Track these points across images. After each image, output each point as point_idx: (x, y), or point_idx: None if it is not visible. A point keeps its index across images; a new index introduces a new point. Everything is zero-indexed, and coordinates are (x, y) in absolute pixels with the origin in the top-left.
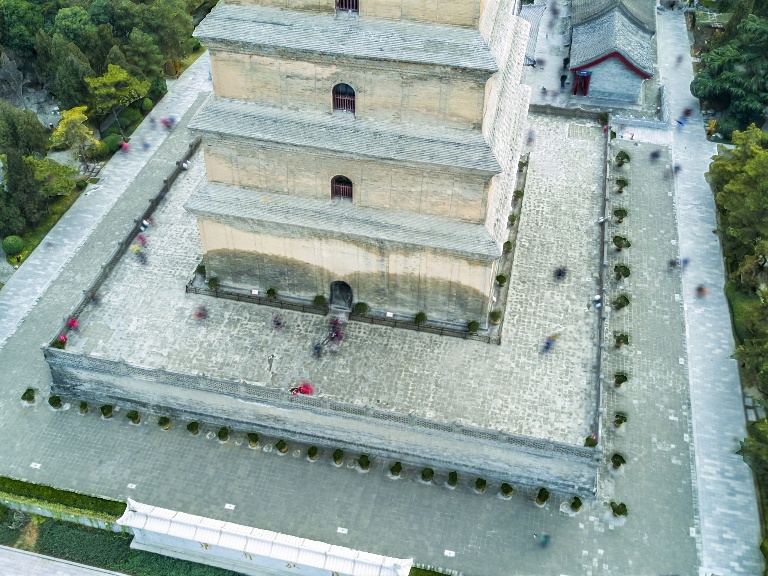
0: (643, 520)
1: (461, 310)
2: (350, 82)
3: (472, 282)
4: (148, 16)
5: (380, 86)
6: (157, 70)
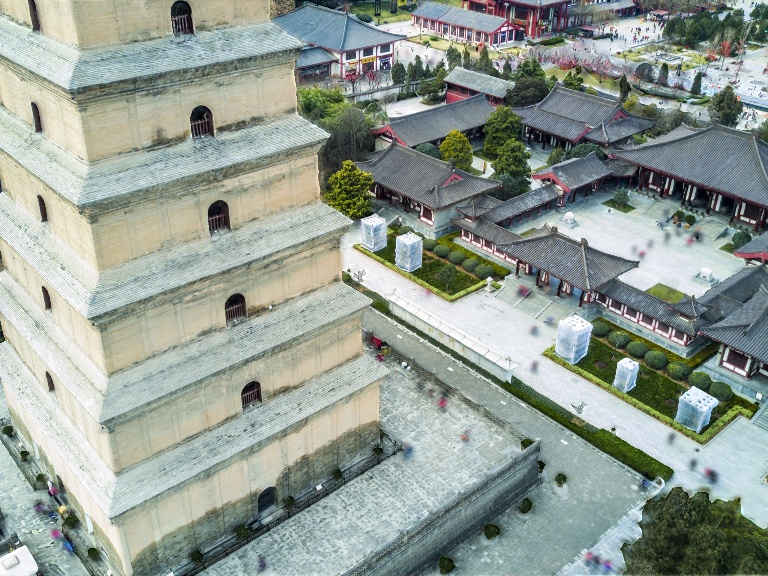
0: None
1: None
2: None
3: None
4: None
5: None
6: None
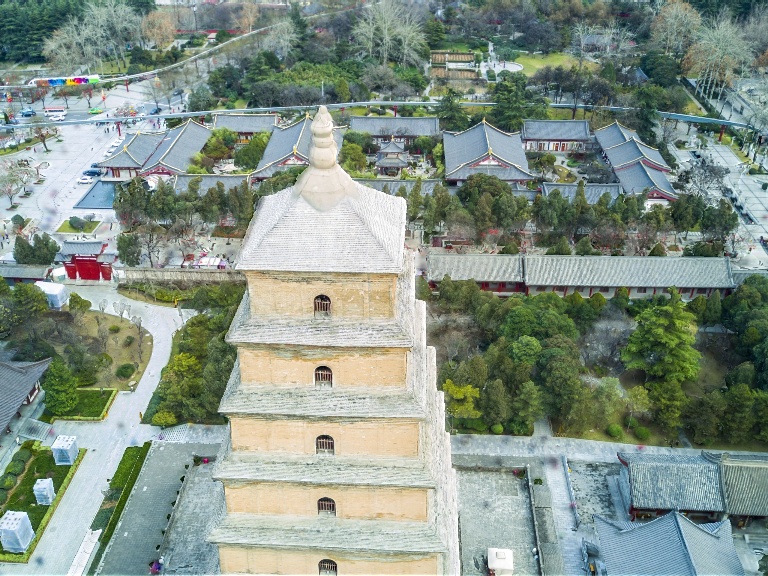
0: None
1: None
2: None
3: None
4: (558, 383)
5: None
6: (527, 417)
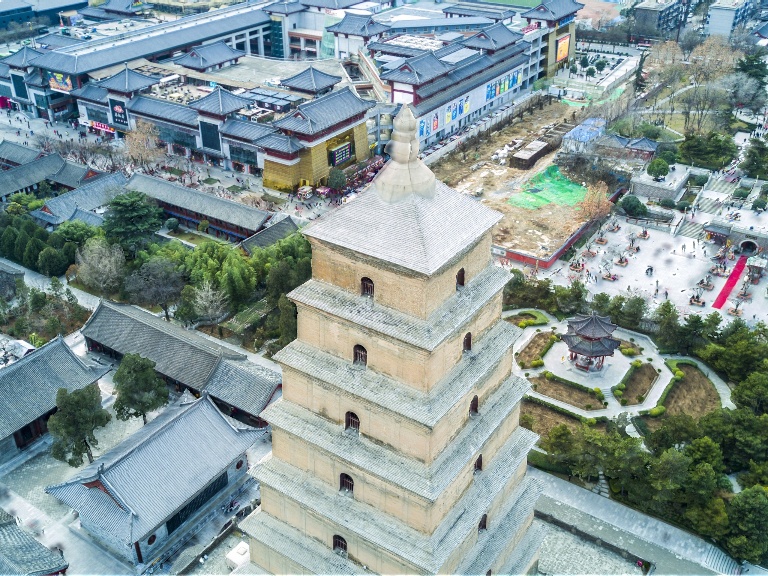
0: (670, 575)
1: None
2: None
3: None
4: None
5: None
6: None
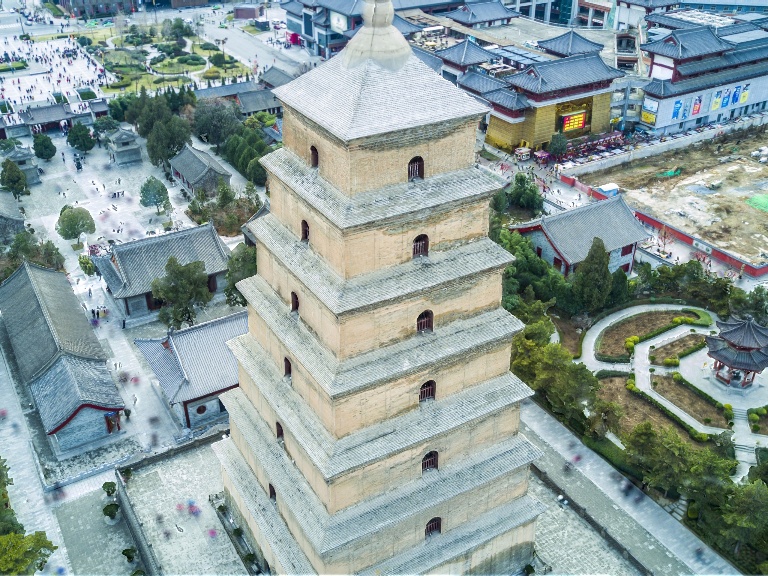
0: None
1: (517, 563)
2: (435, 448)
3: (525, 538)
4: None
5: (456, 440)
6: None
